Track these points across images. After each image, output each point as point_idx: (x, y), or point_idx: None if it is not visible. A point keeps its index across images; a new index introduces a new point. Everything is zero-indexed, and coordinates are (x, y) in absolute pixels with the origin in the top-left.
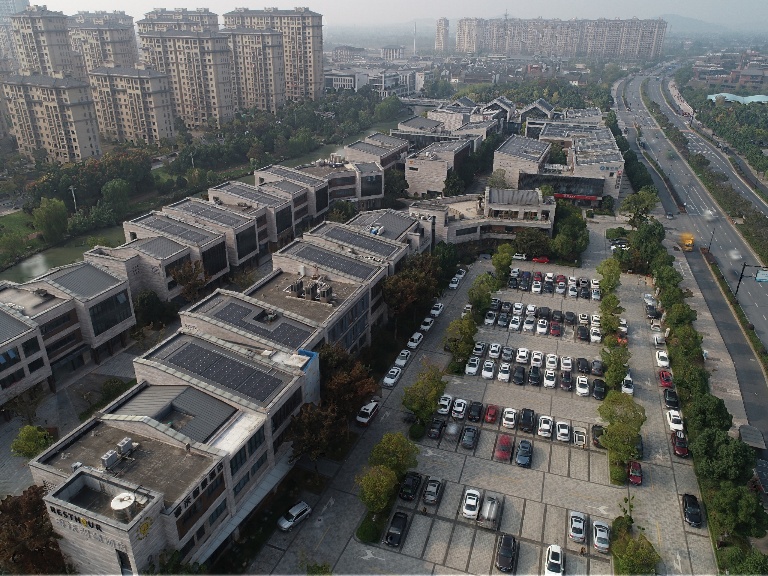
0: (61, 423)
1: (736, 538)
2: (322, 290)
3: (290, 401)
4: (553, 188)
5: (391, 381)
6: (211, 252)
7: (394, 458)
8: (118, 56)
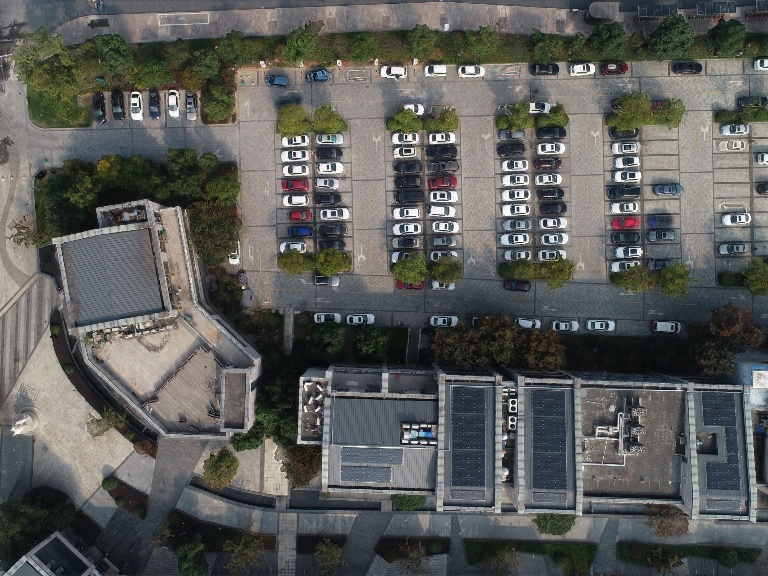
0: (765, 569)
1: None
2: None
3: None
4: None
5: (612, 323)
6: None
7: None
8: None
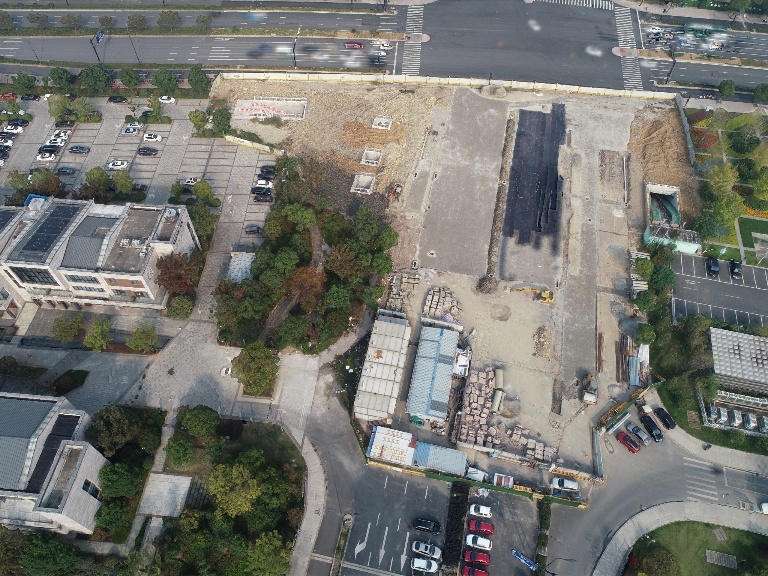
0: None
1: (134, 90)
2: None
3: None
4: None
5: None
6: None
7: (104, 174)
8: None
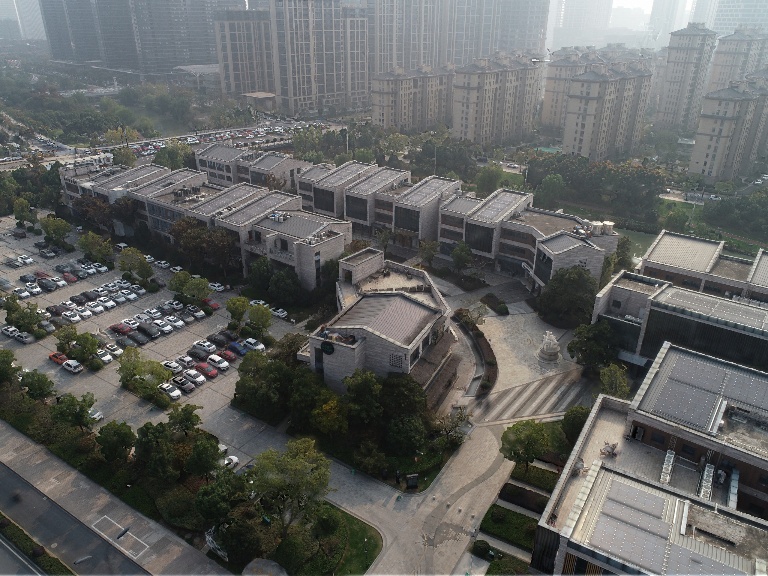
0: None
1: None
2: (176, 190)
3: None
4: None
5: None
6: None
7: None
8: None
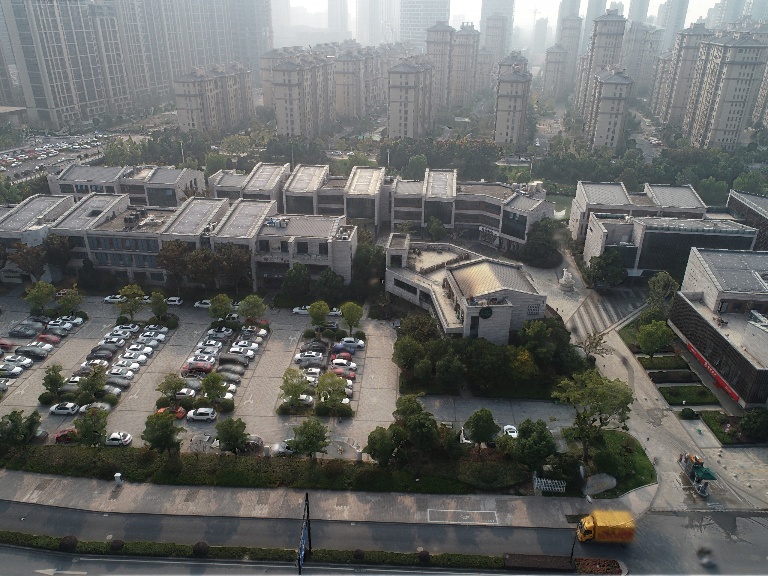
0: None
1: None
2: (125, 216)
3: (13, 241)
4: (697, 340)
5: (106, 298)
6: (254, 197)
7: None
8: (687, 63)
